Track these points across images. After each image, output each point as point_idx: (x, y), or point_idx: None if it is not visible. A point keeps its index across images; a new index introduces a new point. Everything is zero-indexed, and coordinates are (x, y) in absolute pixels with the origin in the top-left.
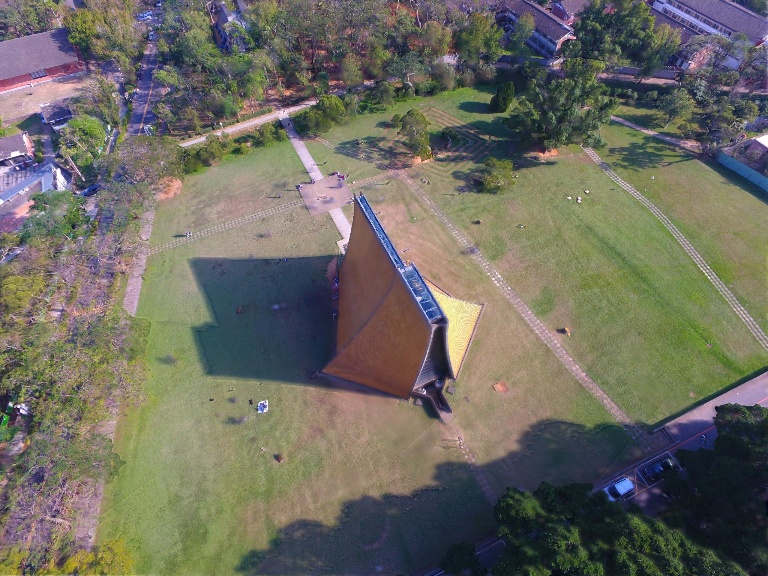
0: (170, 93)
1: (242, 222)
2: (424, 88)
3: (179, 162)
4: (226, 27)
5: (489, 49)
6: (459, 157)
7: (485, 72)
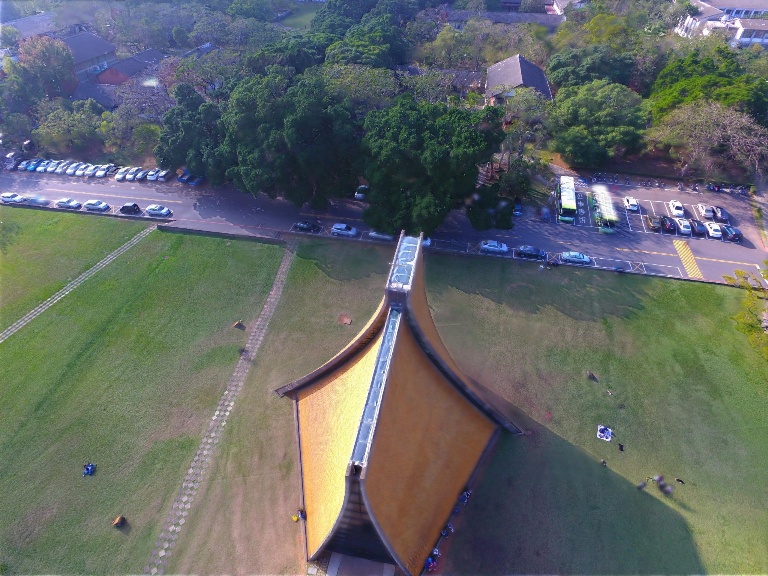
0: None
1: None
2: None
3: None
4: None
5: None
6: None
7: None
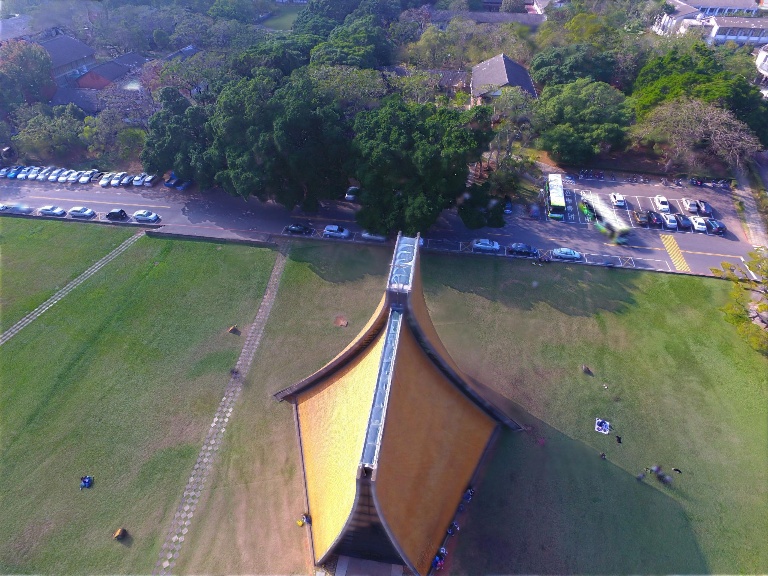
0: None
1: None
2: None
3: None
4: None
5: None
6: None
7: None
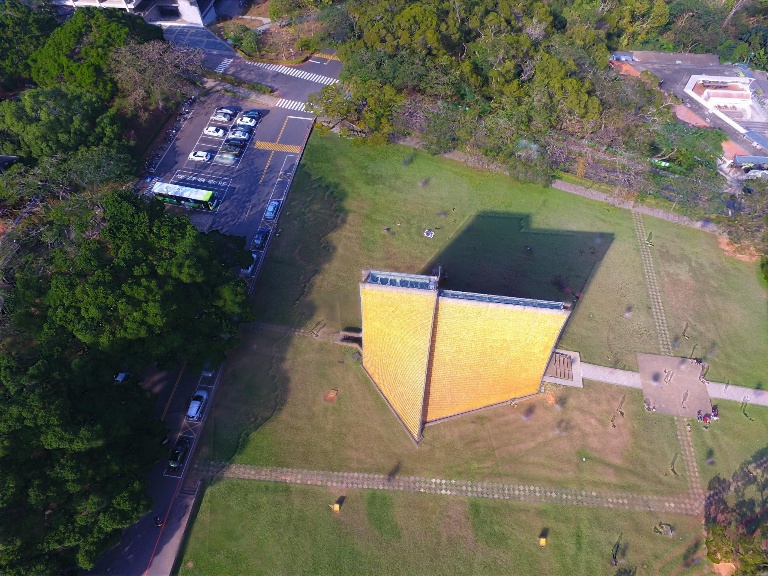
0: None
1: (651, 288)
2: None
3: None
4: None
5: None
6: None
7: None
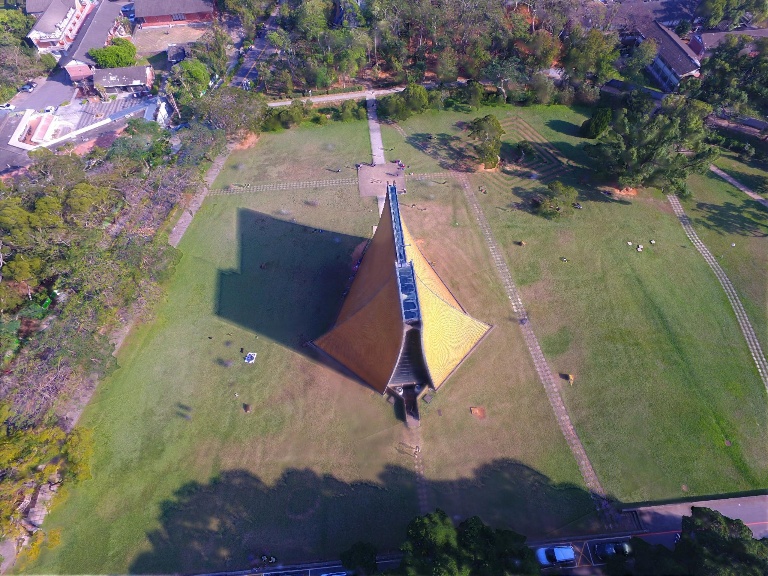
0: (275, 54)
1: (296, 186)
2: (517, 97)
3: (260, 119)
4: (342, 2)
5: (599, 70)
6: (527, 174)
7: (587, 93)
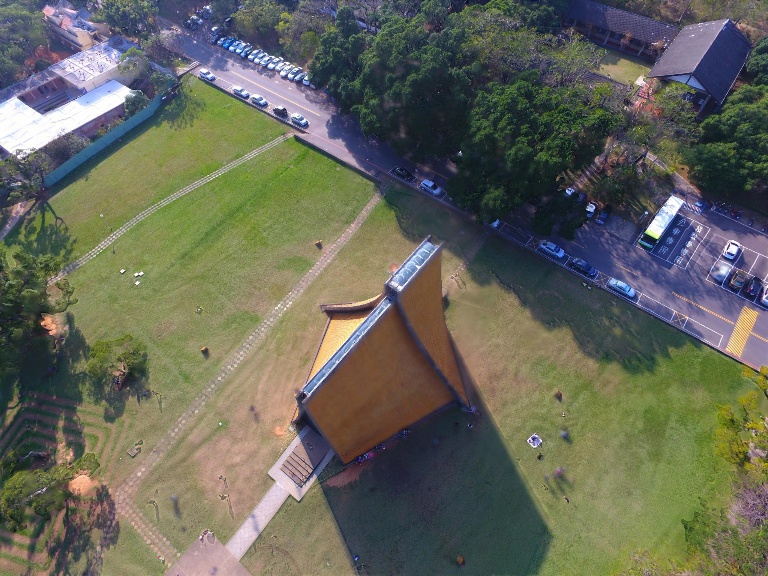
0: None
1: None
2: None
3: None
4: None
5: None
6: (70, 428)
7: None
